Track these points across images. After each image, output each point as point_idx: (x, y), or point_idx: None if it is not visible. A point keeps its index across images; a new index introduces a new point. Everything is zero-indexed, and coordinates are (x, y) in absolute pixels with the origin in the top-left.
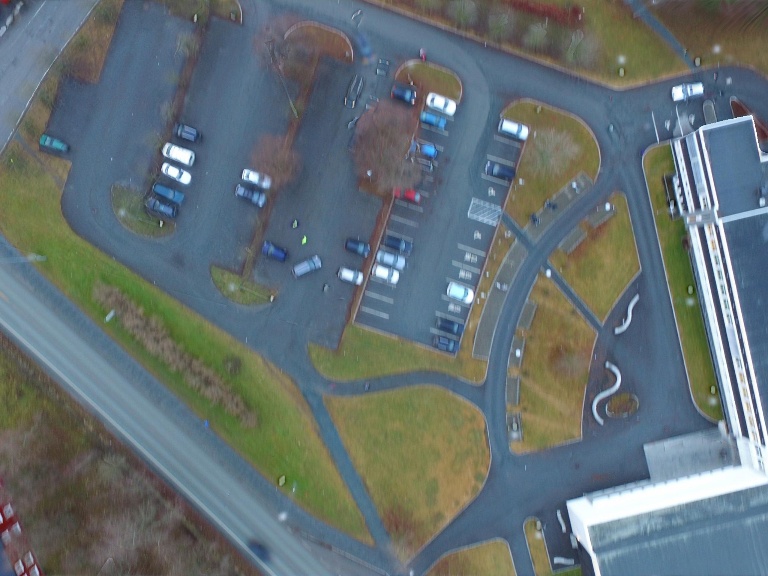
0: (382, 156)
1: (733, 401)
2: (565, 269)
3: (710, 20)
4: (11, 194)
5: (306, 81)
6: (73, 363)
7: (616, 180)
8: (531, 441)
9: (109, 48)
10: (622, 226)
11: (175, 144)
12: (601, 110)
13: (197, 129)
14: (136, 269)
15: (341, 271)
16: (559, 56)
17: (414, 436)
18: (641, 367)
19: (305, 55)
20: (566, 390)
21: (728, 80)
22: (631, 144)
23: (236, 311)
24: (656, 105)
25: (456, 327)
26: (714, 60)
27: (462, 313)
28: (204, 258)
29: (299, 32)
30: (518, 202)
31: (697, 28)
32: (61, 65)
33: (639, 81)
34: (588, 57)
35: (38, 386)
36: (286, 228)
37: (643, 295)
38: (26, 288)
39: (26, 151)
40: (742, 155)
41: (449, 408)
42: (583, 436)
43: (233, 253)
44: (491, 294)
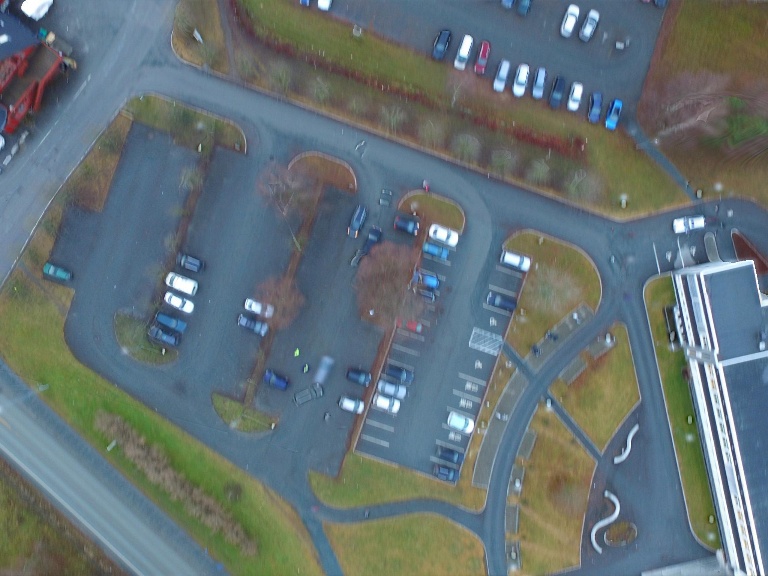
0: (384, 288)
1: (731, 534)
2: (565, 399)
3: (712, 155)
4: (14, 322)
5: (309, 211)
6: (74, 490)
7: (617, 311)
8: (530, 569)
9: (114, 177)
10: (622, 356)
11: (178, 273)
12: (603, 241)
13: (200, 259)
14: (138, 396)
15: (342, 401)
16: (562, 188)
17: (413, 564)
18: (640, 496)
19: (309, 185)
20: (565, 519)
21: (729, 213)
22: (632, 275)
23: (237, 438)
24: (658, 236)
25: (456, 457)
26: (716, 192)
27: (462, 442)
28: (206, 385)
29: (303, 162)
30: (519, 332)
31: (699, 160)
32: (66, 194)
33: (641, 213)
34: (590, 189)
35: (39, 513)
36: (288, 356)
37: (643, 425)
38: (28, 415)
39: (30, 279)
40: (743, 299)
41: (448, 536)
42: (581, 564)
43: (235, 380)
44: (491, 423)
